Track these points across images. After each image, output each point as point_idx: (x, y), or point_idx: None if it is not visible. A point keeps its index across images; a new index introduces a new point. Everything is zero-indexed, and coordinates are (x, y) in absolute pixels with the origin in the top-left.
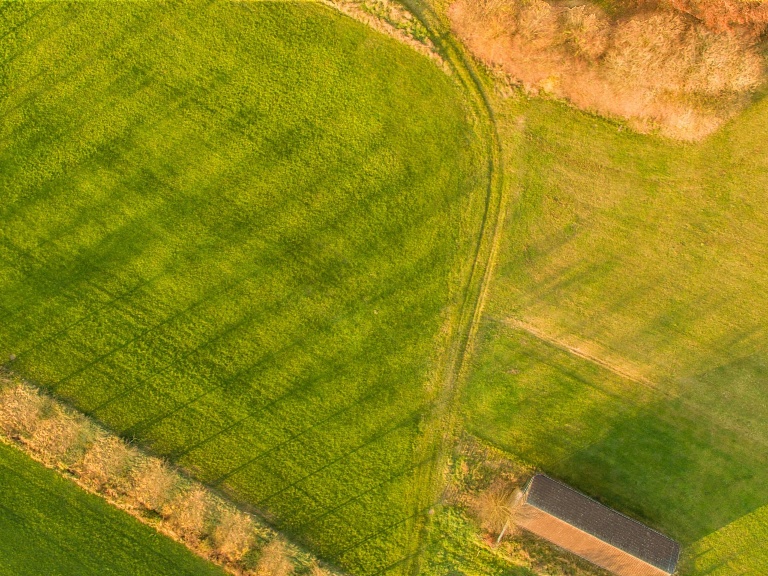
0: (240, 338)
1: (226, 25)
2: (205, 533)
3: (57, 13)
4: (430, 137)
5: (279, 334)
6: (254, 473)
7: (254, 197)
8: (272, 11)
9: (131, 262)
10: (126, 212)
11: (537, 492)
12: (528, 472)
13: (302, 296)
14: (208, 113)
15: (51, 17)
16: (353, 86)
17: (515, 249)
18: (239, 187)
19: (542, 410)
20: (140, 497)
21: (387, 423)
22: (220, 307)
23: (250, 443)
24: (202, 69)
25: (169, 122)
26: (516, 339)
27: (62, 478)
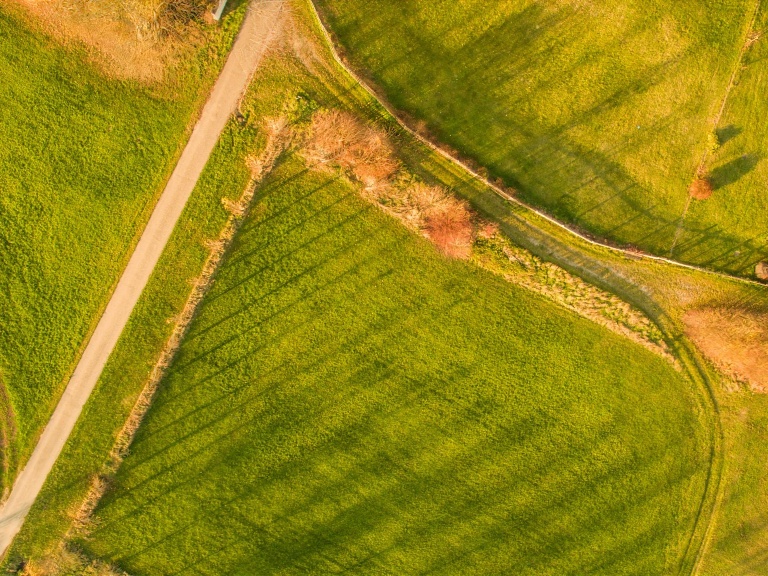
0: None
1: (468, 324)
2: None
3: (303, 310)
4: (657, 426)
5: None
6: None
7: (485, 478)
8: (513, 312)
9: (363, 536)
10: (360, 491)
11: None
12: None
13: (526, 566)
14: (445, 403)
15: (296, 314)
16: (587, 380)
17: (731, 525)
18: (471, 469)
19: None
20: None
21: None
22: None
23: None
24: (442, 363)
25: (407, 410)
26: None
27: None
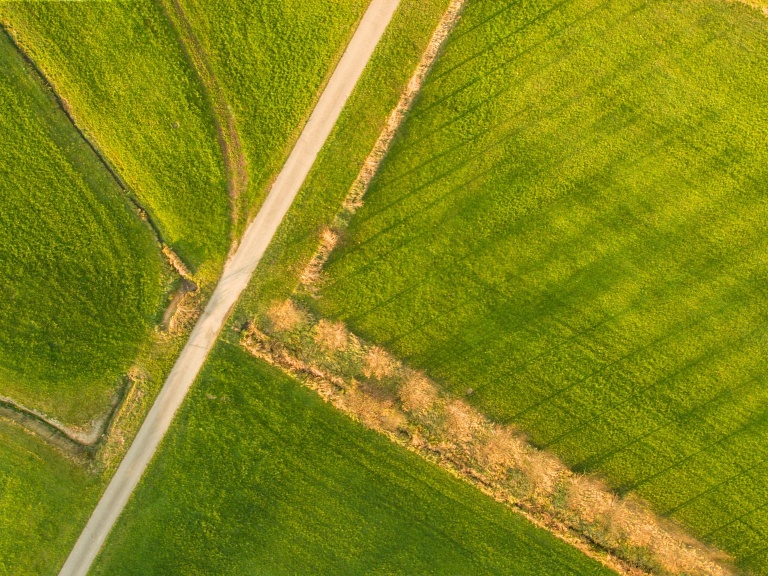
0: (699, 373)
1: (721, 64)
2: (649, 567)
3: (549, 50)
4: None
5: (739, 370)
6: (701, 507)
7: (729, 234)
8: None
9: (598, 298)
10: (598, 248)
11: None
12: None
13: (766, 332)
14: (692, 151)
15: (542, 54)
16: None
17: None
18: (715, 224)
19: None
20: (586, 531)
21: None
22: (683, 343)
23: (700, 477)
24: (691, 107)
25: (652, 159)
26: None
27: (511, 512)
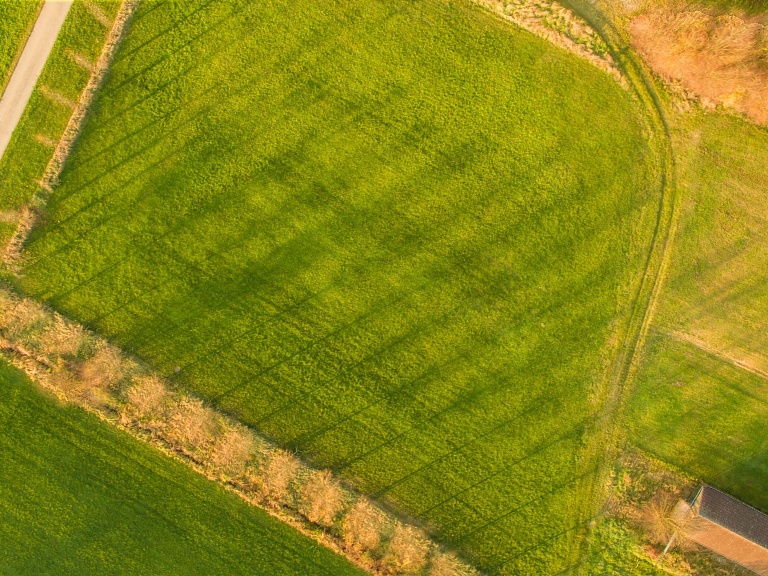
0: (406, 351)
1: (404, 39)
2: (366, 545)
3: (234, 27)
4: (605, 151)
5: (445, 347)
6: (416, 485)
7: (425, 210)
8: (451, 25)
9: (299, 275)
10: (296, 225)
11: (708, 504)
12: (690, 484)
13: (470, 309)
14: (382, 127)
15: (227, 30)
16: (529, 100)
17: (685, 262)
18: (411, 200)
19: (705, 422)
20: (301, 509)
21: (550, 435)
22: (387, 320)
23: (413, 455)
24: (378, 83)
25: (343, 135)
26: (681, 352)
27: (224, 490)
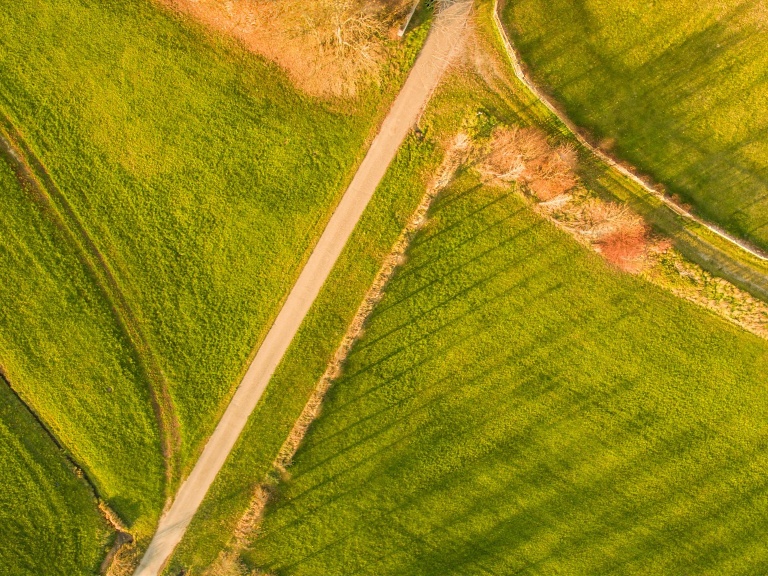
0: None
1: (634, 338)
2: None
3: (470, 323)
4: None
5: None
6: None
7: (643, 490)
8: (679, 326)
9: (519, 547)
10: (519, 502)
11: None
12: None
13: None
14: (607, 415)
15: (464, 326)
16: (748, 393)
17: None
18: (630, 481)
19: None
20: None
21: None
22: None
23: None
24: (606, 376)
25: (569, 422)
26: None
27: None
